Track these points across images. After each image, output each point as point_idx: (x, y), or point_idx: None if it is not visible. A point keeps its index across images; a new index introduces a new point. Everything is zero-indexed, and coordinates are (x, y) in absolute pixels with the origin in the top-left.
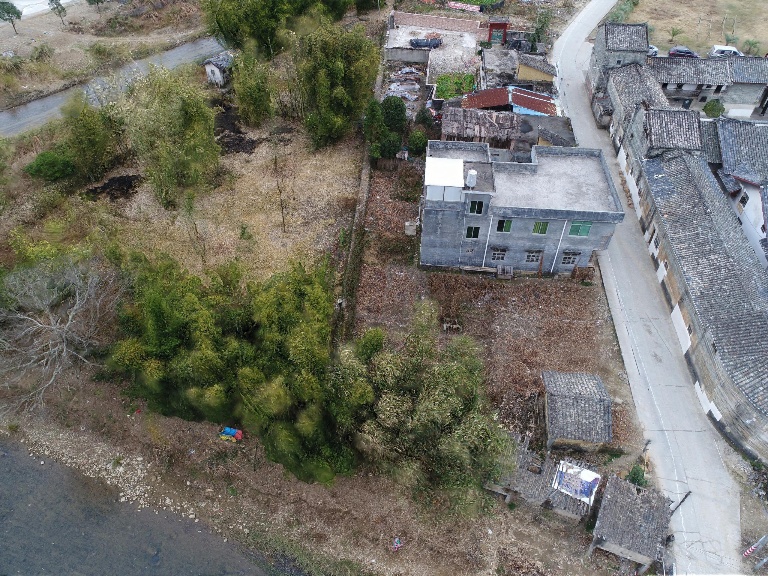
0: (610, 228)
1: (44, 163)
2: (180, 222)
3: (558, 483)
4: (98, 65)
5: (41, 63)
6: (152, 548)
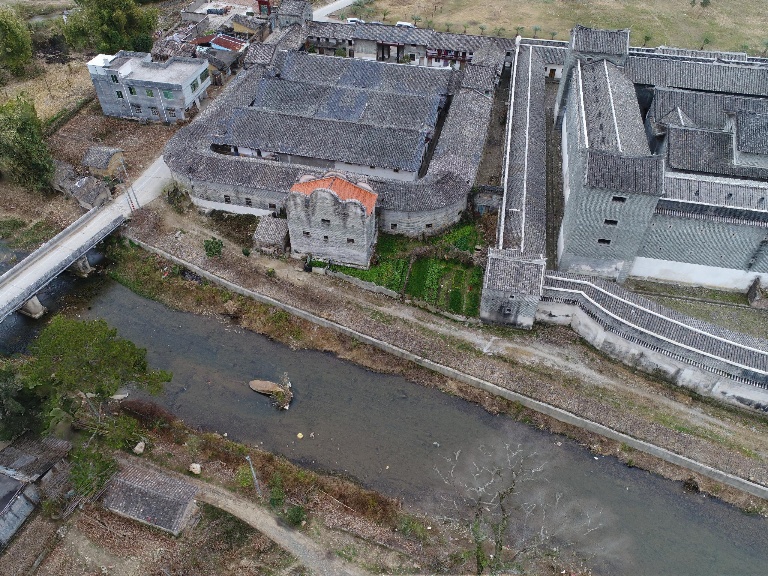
0: (181, 94)
1: None
2: (3, 92)
3: None
4: (17, 16)
5: None
6: None
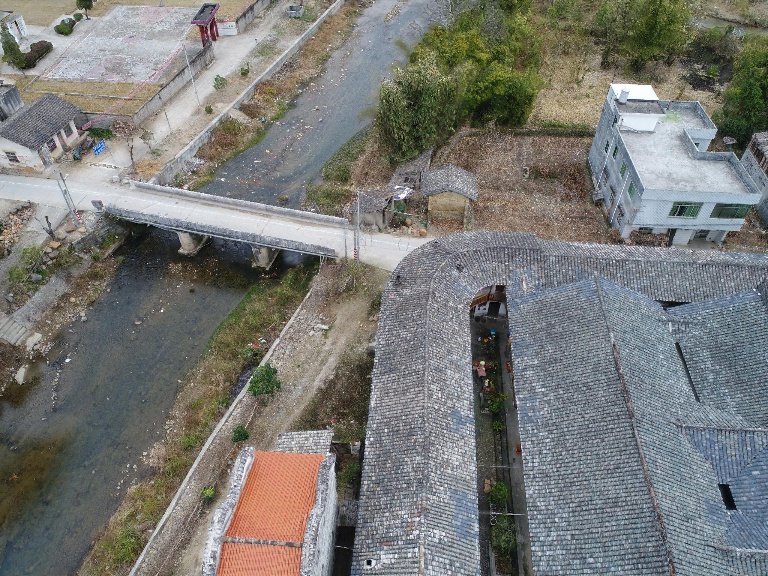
0: (639, 202)
1: (604, 11)
2: (591, 74)
3: (398, 188)
4: None
5: (748, 2)
6: (371, 103)
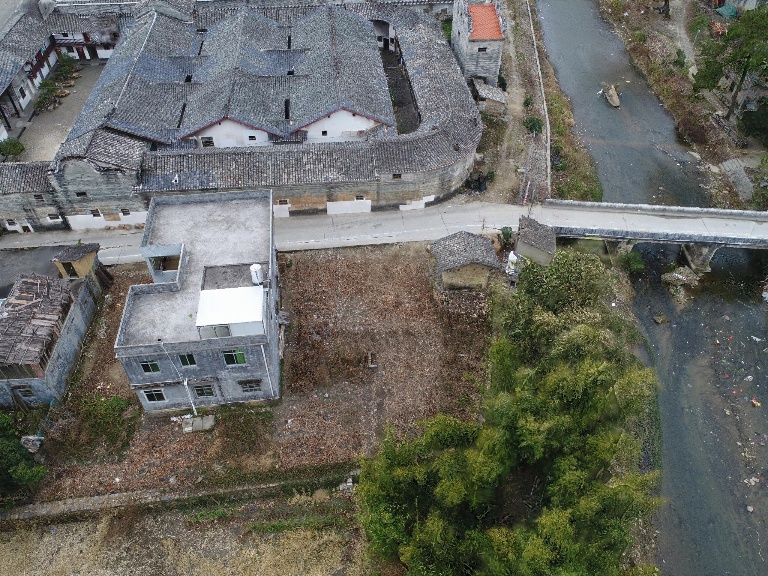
0: None
1: None
2: None
3: None
4: None
5: None
6: None
